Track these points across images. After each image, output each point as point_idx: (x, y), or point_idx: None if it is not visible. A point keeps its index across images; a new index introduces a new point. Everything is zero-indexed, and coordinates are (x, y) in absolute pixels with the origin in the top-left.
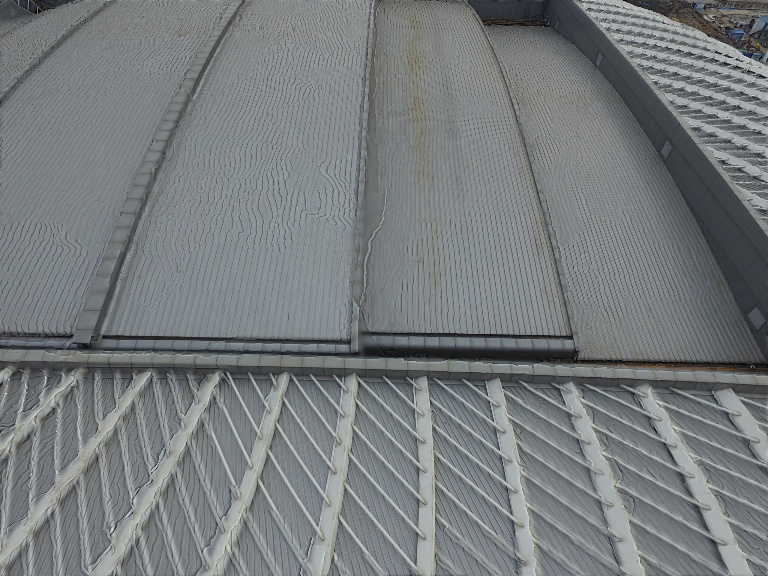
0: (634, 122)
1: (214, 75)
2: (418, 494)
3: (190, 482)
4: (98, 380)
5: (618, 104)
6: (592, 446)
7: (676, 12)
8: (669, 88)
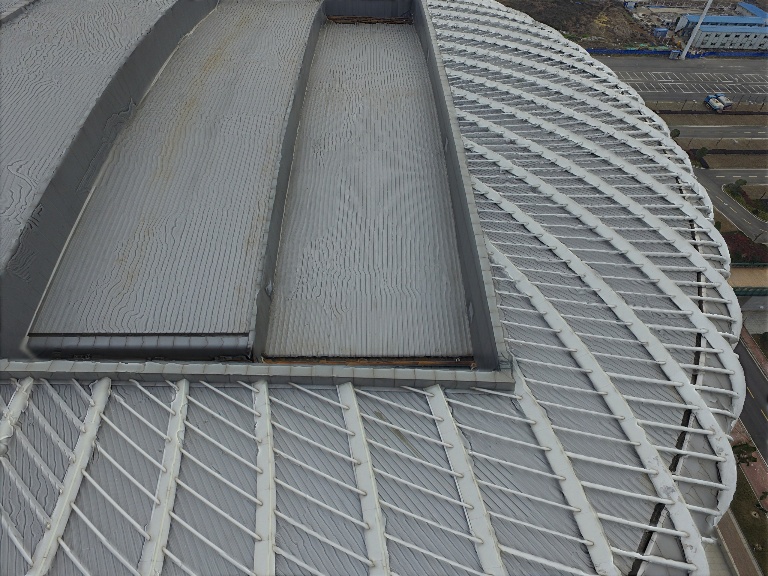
0: (434, 118)
1: None
2: None
3: None
4: None
5: (427, 100)
6: (171, 444)
7: (607, 10)
8: (467, 84)
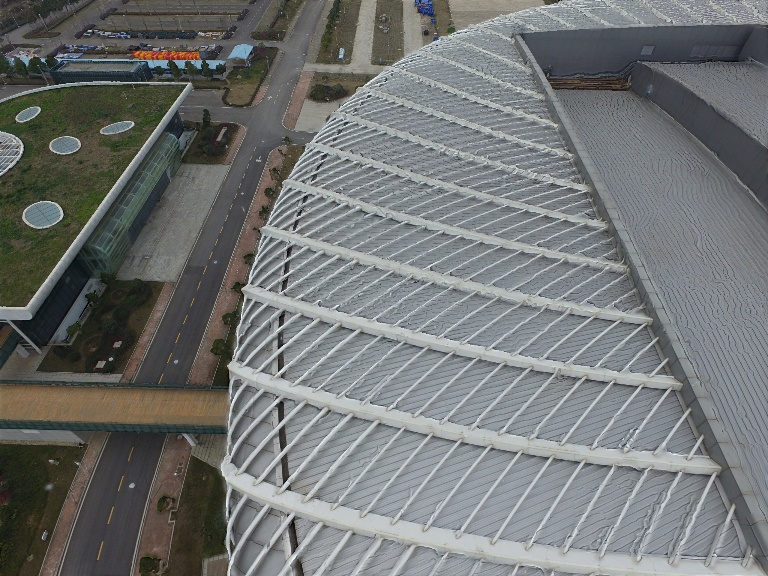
0: None
1: None
2: None
3: None
4: None
5: None
6: None
7: None
8: (562, 198)
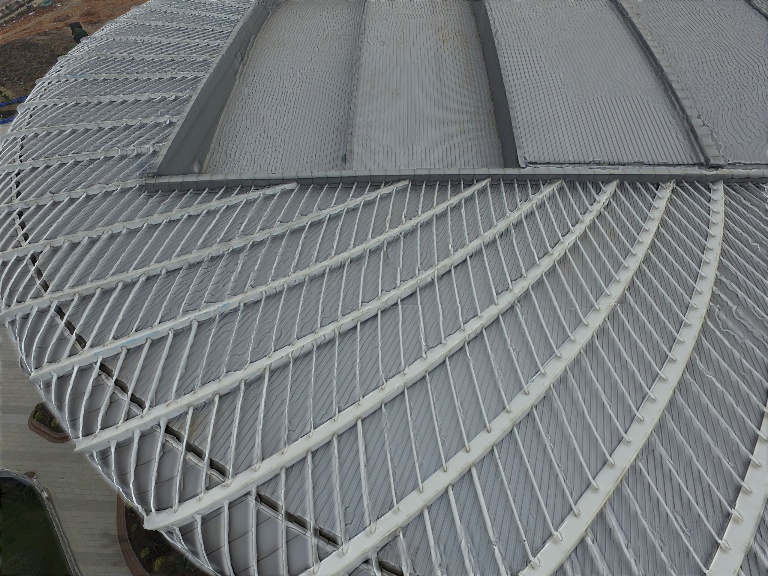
0: None
1: (633, 7)
2: None
3: None
4: (742, 186)
5: None
6: None
7: None
8: None
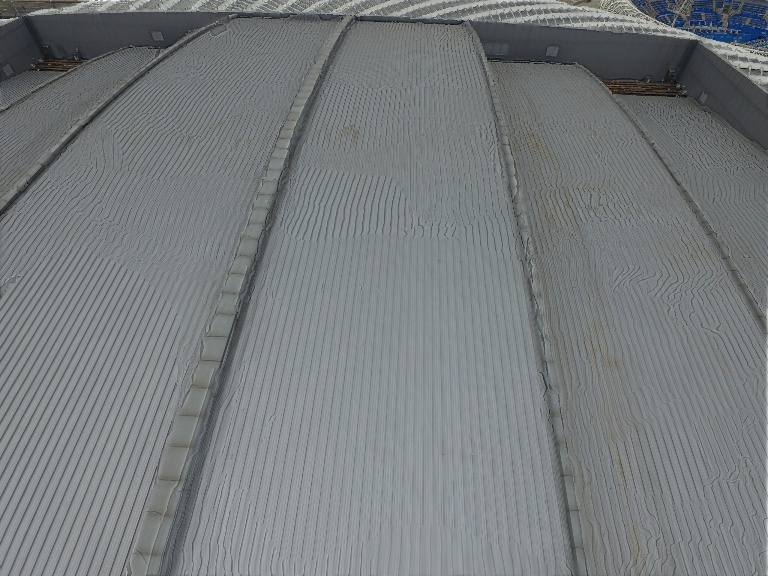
0: None
1: None
2: (230, 5)
3: (303, 6)
4: None
5: None
6: (162, 8)
7: None
8: None
